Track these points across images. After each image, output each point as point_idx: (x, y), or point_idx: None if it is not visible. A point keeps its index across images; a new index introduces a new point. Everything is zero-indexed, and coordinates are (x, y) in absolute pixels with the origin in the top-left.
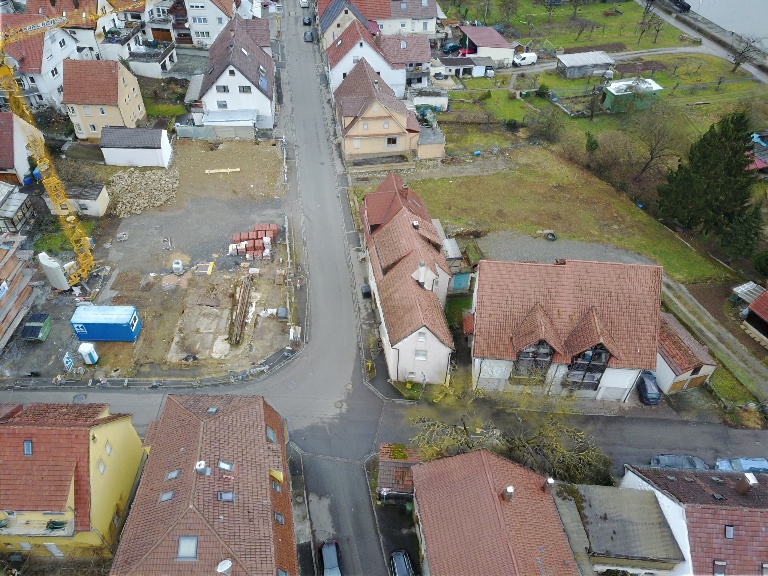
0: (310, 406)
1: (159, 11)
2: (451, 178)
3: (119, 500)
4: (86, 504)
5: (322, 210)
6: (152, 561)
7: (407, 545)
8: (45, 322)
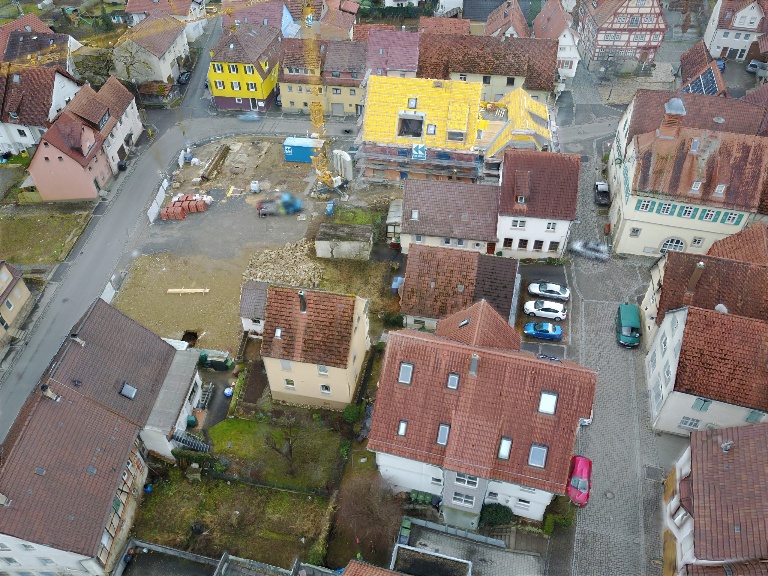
0: None
1: None
2: None
3: None
4: None
5: (108, 239)
6: None
7: None
8: None
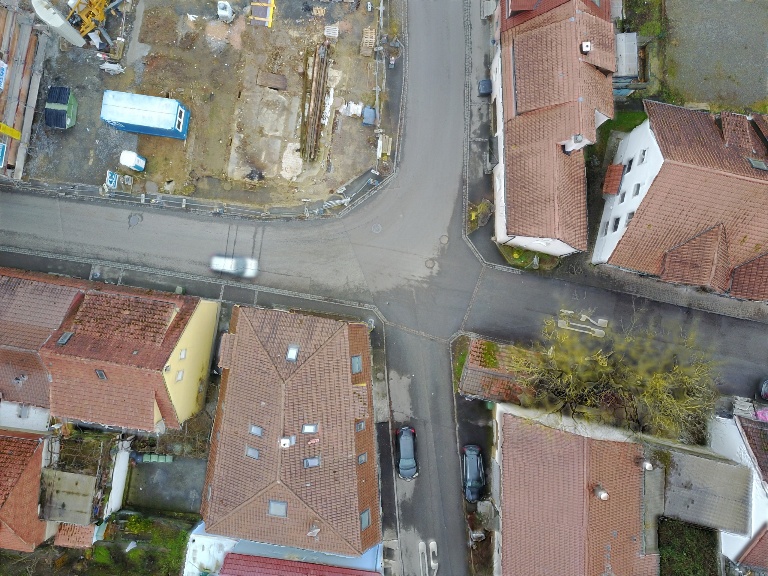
0: (397, 262)
1: None
2: None
3: (201, 372)
4: (172, 416)
5: None
6: (246, 512)
7: (482, 439)
8: (68, 102)
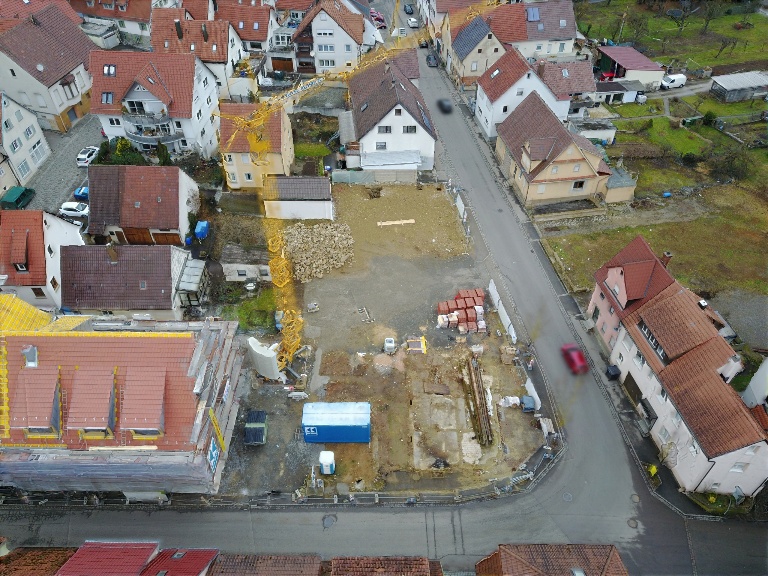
0: (600, 526)
1: (278, 38)
2: (650, 226)
3: None
4: None
5: (521, 268)
6: None
7: None
8: (265, 421)
